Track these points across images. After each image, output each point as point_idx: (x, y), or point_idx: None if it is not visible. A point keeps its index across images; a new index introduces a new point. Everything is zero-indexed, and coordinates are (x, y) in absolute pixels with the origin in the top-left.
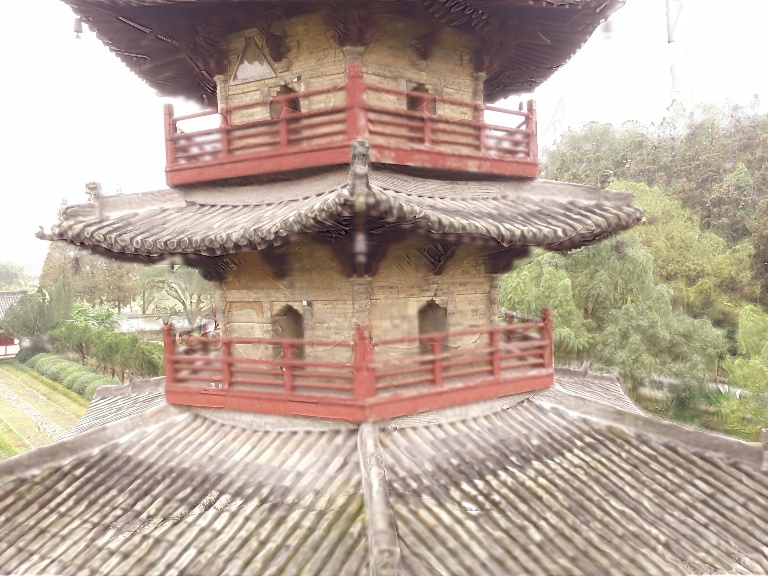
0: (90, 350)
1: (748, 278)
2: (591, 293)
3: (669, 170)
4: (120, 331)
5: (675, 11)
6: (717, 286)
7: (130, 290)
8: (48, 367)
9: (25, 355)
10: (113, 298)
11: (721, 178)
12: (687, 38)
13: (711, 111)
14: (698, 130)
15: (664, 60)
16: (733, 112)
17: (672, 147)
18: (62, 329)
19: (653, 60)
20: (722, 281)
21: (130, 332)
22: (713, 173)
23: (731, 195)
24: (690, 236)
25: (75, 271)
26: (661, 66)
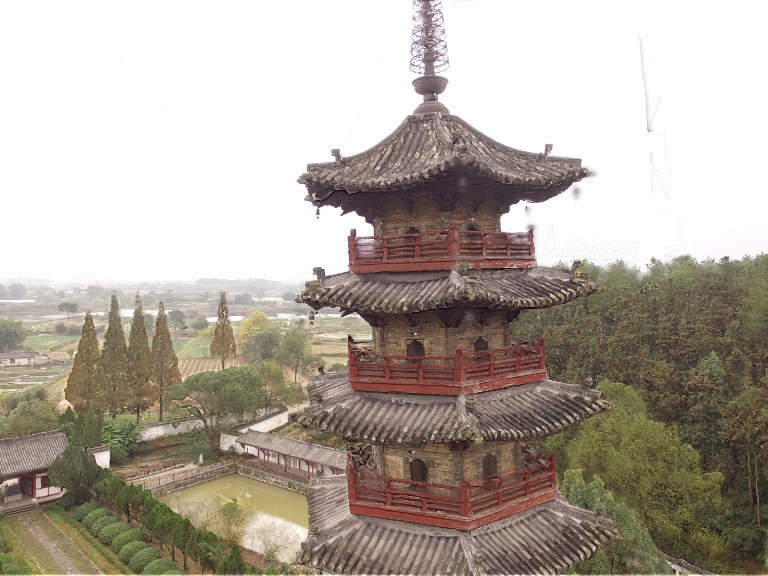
0: (136, 510)
1: (719, 504)
2: (593, 568)
3: (651, 338)
4: (141, 440)
5: (654, 103)
6: (694, 510)
7: (149, 397)
8: (98, 528)
9: (69, 502)
10: (134, 406)
11: (697, 356)
12: (665, 128)
13: (687, 280)
14: (676, 295)
15: (644, 153)
16: (707, 278)
17: (654, 307)
18: (106, 481)
19: (634, 152)
20: (698, 505)
21: (150, 440)
22: (690, 348)
23: (705, 384)
24: (671, 453)
25: (97, 380)
26: (642, 158)
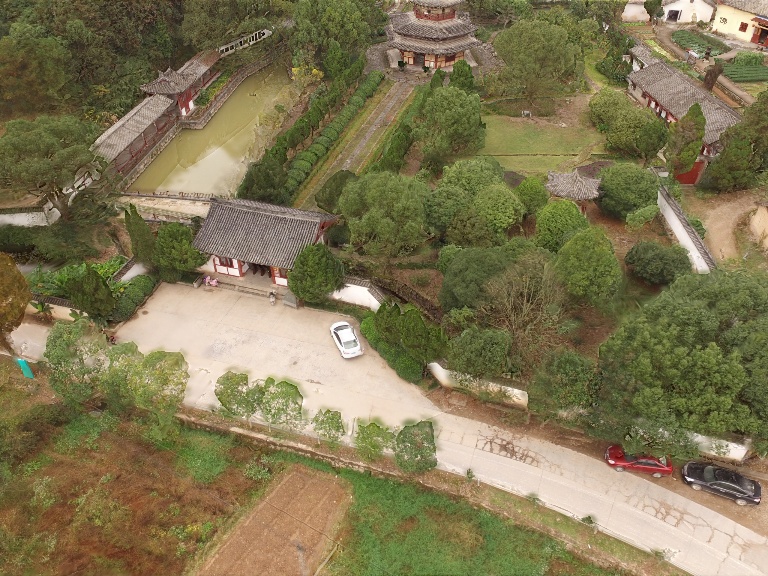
0: None
1: None
2: None
3: None
4: None
5: None
6: None
7: None
8: None
9: None
10: None
11: None
12: None
13: None
14: None
15: None
16: None
17: None
18: None
19: None
20: None
21: None
22: None
23: None
24: None
25: None
26: None
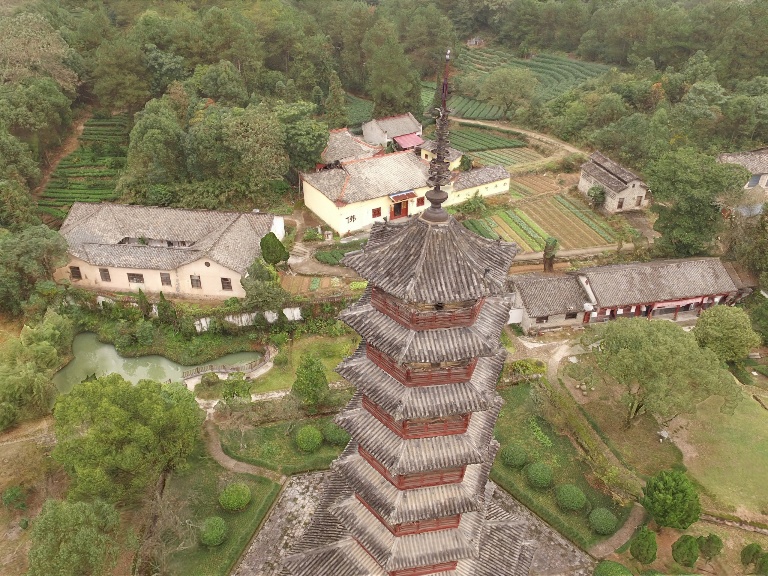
0: None
1: None
2: None
3: None
4: None
5: None
6: None
7: None
8: None
9: None
10: None
11: None
12: None
13: None
14: None
15: None
16: None
17: None
18: None
19: None
20: None
21: None
22: None
23: None
24: None
25: None
26: None
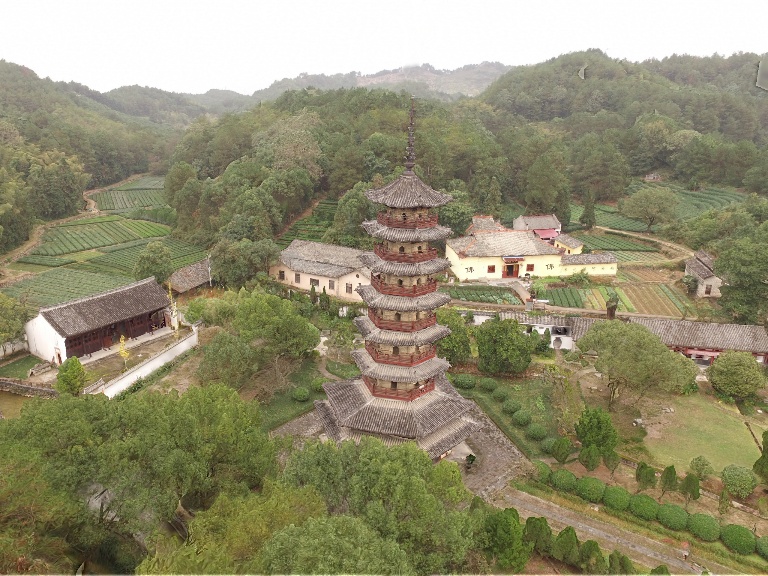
0: None
1: None
2: None
3: None
4: None
5: None
6: None
7: None
8: None
9: None
10: None
11: None
12: None
13: None
14: None
15: None
16: None
17: None
18: None
19: None
20: None
21: None
22: None
23: None
24: None
25: None
26: None
